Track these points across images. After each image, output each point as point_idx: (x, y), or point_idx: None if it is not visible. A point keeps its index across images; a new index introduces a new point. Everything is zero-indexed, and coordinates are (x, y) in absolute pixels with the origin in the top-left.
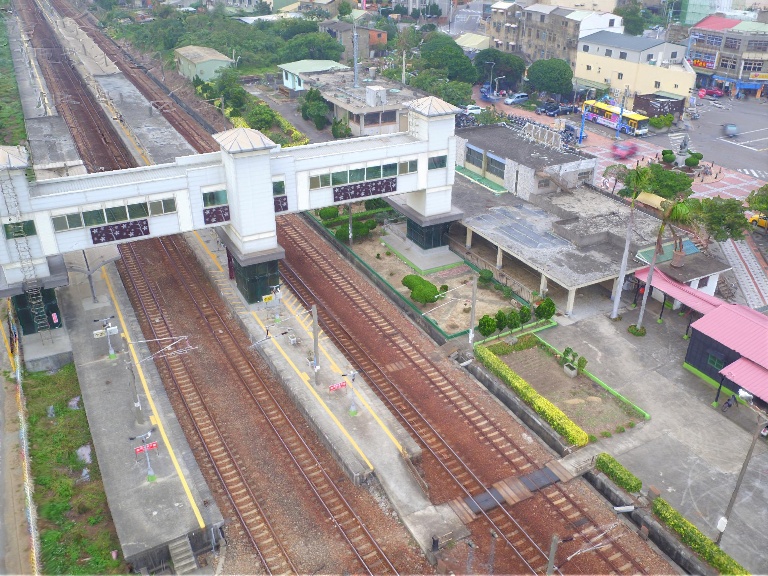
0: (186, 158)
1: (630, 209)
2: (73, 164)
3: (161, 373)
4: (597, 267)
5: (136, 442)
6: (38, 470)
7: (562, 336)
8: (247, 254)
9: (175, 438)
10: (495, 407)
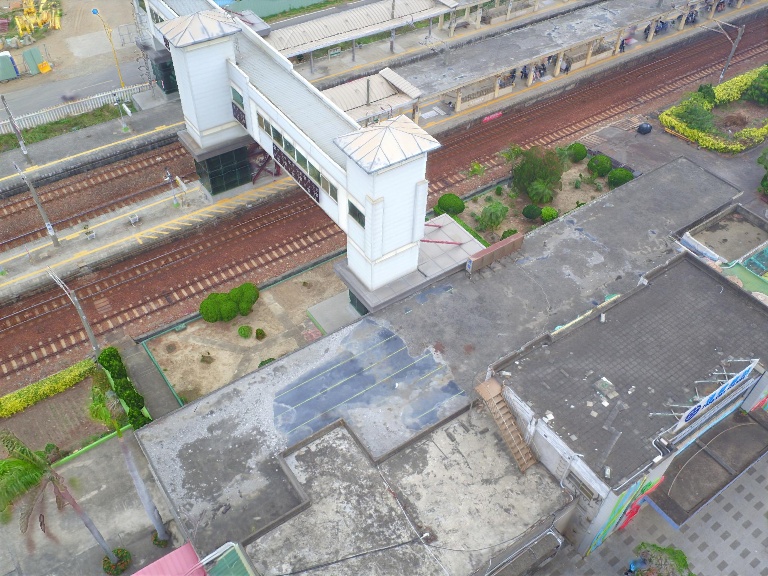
0: (239, 22)
1: (460, 574)
2: (447, 3)
3: (119, 163)
4: (202, 478)
5: (5, 166)
6: (3, 138)
7: (122, 460)
8: (188, 133)
9: (5, 182)
10: (7, 389)
